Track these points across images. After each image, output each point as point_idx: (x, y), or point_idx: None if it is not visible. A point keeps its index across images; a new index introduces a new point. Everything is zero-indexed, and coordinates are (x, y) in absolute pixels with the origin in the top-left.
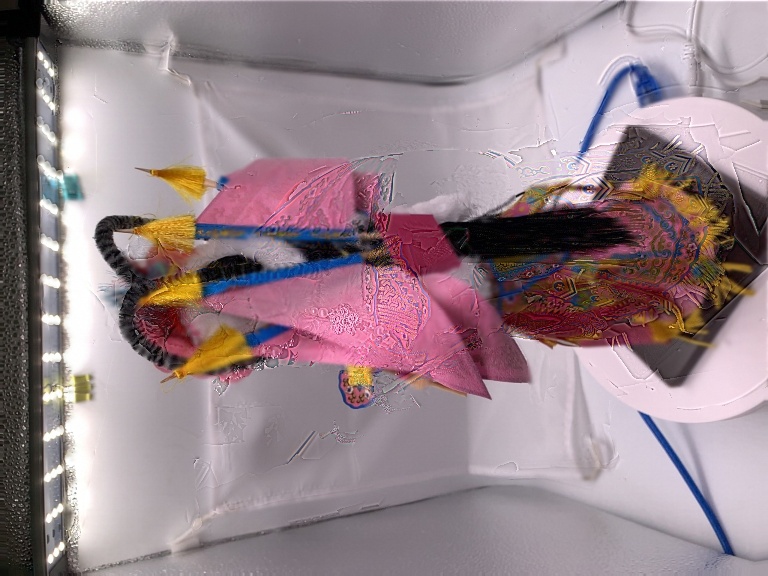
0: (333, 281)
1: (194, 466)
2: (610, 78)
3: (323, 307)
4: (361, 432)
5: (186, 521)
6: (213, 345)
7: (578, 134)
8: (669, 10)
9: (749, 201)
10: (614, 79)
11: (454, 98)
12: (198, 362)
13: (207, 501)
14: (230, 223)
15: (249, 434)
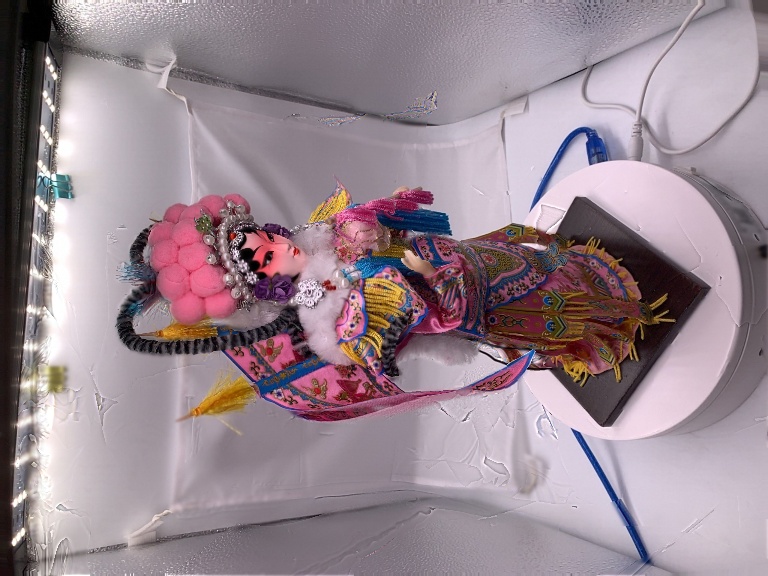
0: None
1: None
2: None
3: None
4: None
5: None
6: None
7: None
8: (528, 394)
9: (551, 224)
10: None
11: None
12: None
13: None
14: None
15: None
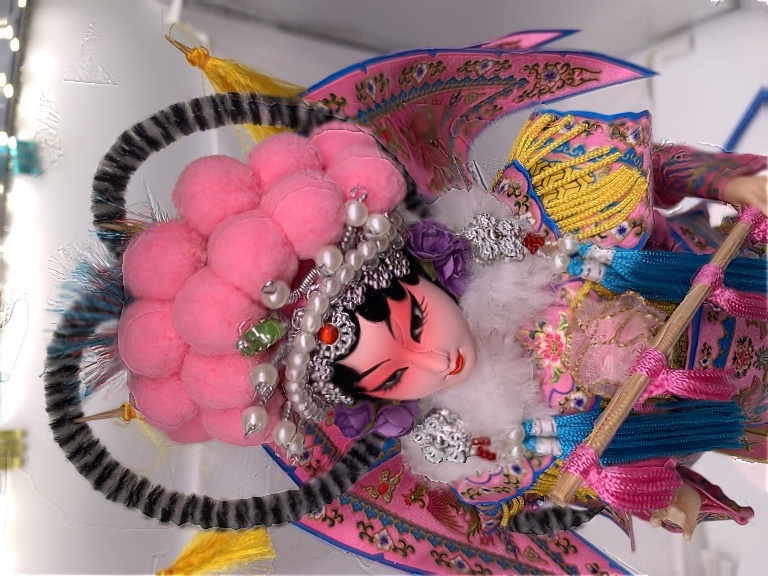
0: (445, 201)
1: None
2: None
3: None
4: None
5: None
6: (235, 195)
7: None
8: None
9: None
10: None
11: None
12: (202, 272)
13: None
14: None
15: None
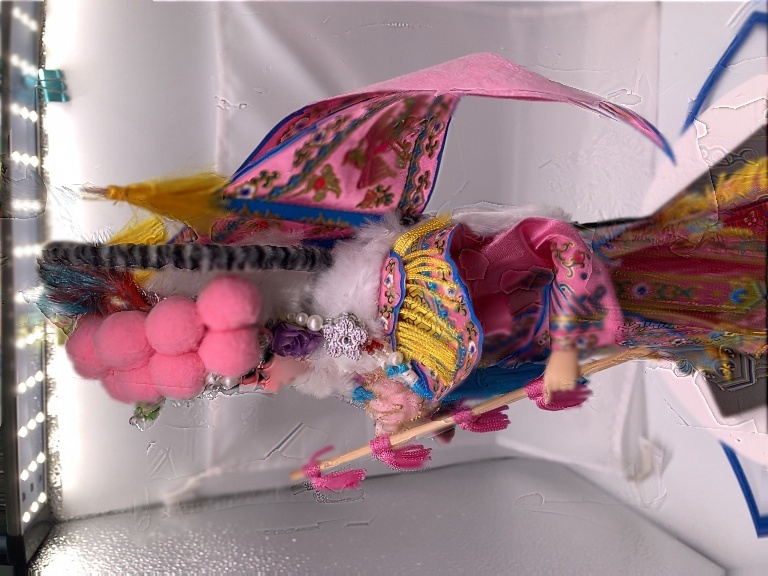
0: (336, 277)
1: (148, 451)
2: (744, 19)
3: (316, 314)
4: (351, 488)
5: (132, 515)
6: (130, 365)
7: (687, 89)
8: None
9: None
10: (749, 21)
11: (534, 21)
12: (110, 382)
13: (159, 497)
14: (171, 174)
15: (221, 418)
